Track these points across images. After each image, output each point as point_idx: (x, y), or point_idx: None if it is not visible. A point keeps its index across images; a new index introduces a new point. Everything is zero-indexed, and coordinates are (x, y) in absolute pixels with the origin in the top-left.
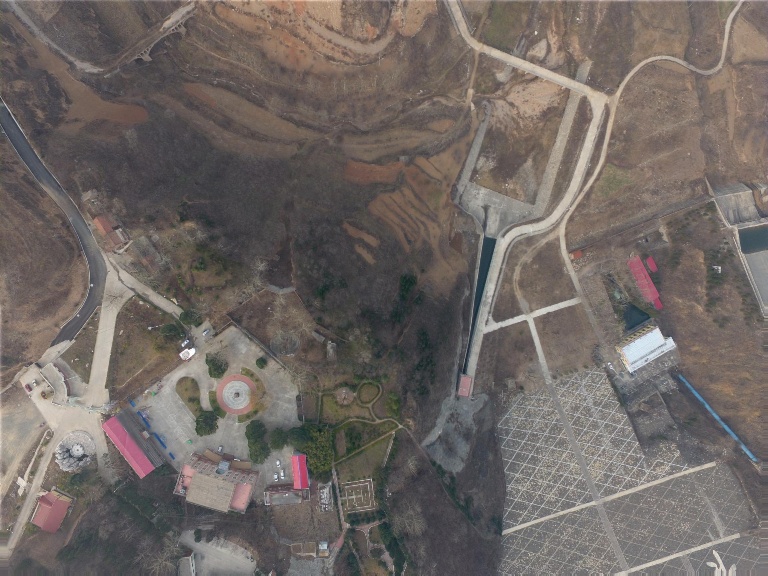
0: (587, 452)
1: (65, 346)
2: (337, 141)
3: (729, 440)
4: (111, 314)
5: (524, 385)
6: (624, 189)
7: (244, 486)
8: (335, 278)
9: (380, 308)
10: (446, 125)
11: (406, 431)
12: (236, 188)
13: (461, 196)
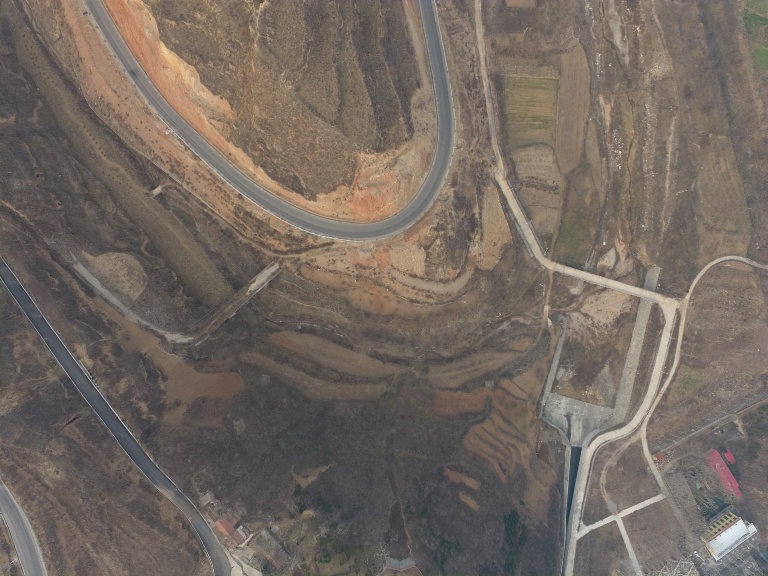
0: None
1: None
2: (423, 373)
3: None
4: None
5: None
6: (699, 388)
7: None
8: (451, 545)
9: (494, 564)
10: (526, 343)
11: None
12: (340, 453)
13: (544, 407)
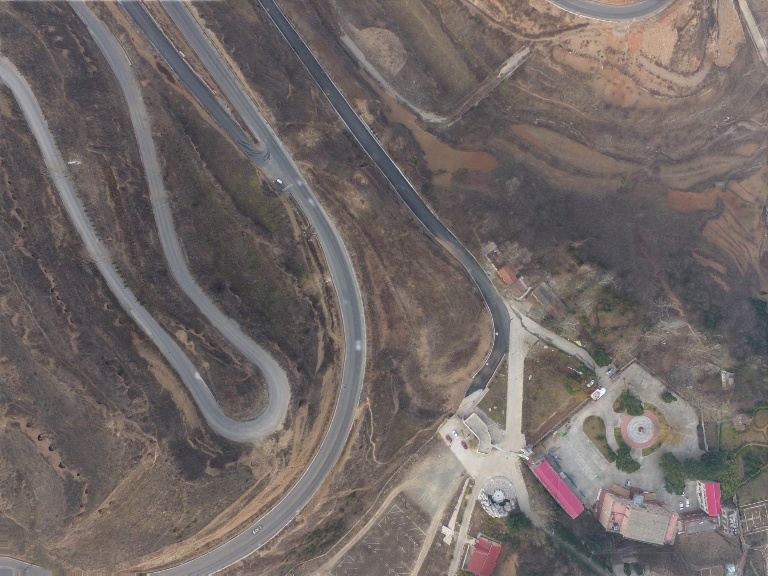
0: None
1: (479, 395)
2: (656, 172)
3: None
4: (518, 360)
5: None
6: None
7: (672, 518)
8: (719, 309)
9: (756, 334)
10: (752, 149)
11: None
12: (597, 227)
13: (766, 216)
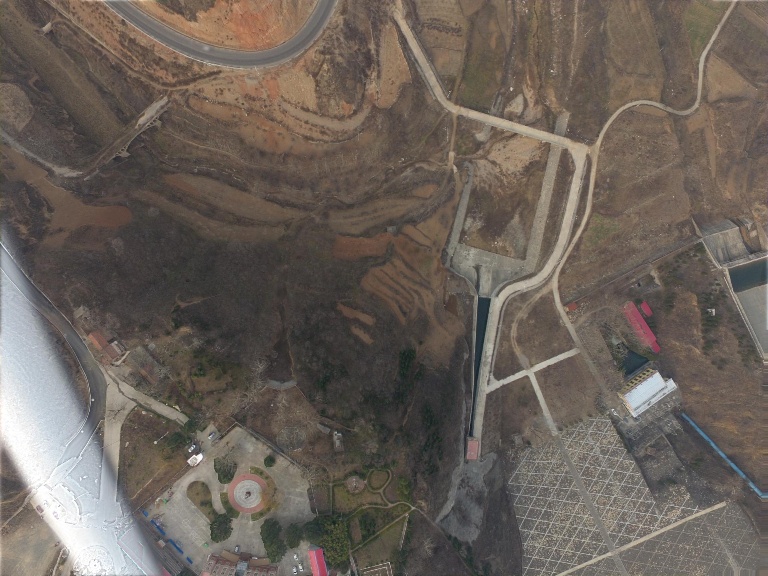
0: (599, 502)
1: (72, 464)
2: (323, 218)
3: (737, 479)
4: (115, 427)
5: (531, 439)
6: (612, 237)
7: None
8: (335, 368)
9: (382, 391)
10: (430, 190)
11: (419, 512)
12: (227, 282)
13: (452, 258)
